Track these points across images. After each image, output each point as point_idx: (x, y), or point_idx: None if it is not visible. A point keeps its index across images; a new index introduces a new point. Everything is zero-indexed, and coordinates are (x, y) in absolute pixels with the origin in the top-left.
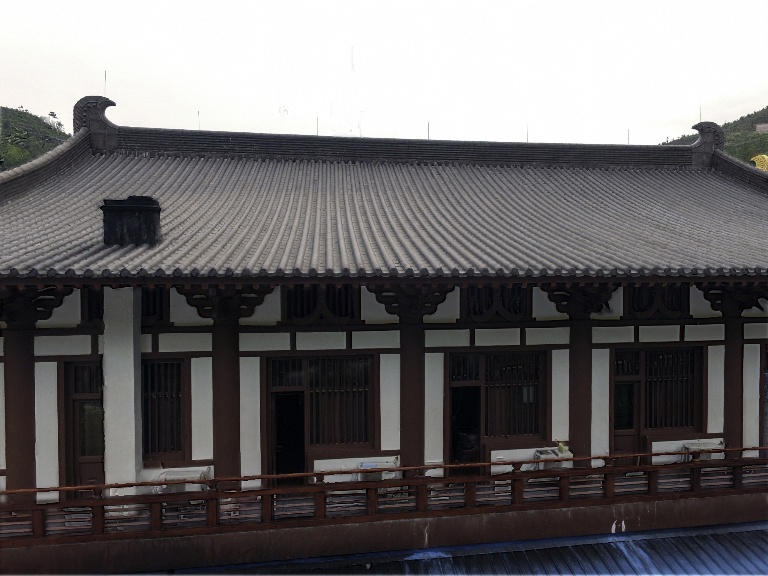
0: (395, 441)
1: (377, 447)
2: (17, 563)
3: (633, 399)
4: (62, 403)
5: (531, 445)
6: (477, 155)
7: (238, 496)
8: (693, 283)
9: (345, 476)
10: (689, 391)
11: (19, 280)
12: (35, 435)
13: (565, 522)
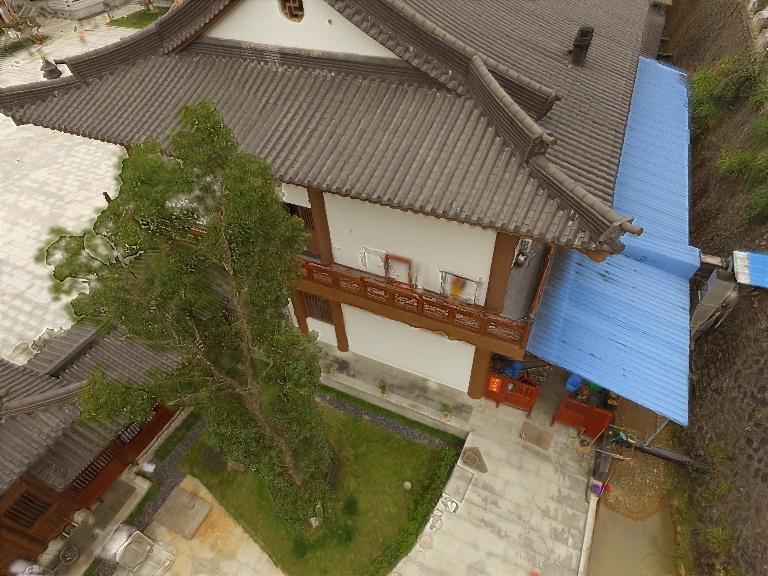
0: None
1: None
2: None
3: None
4: None
5: None
6: None
7: None
8: None
9: None
10: None
11: None
12: None
13: None
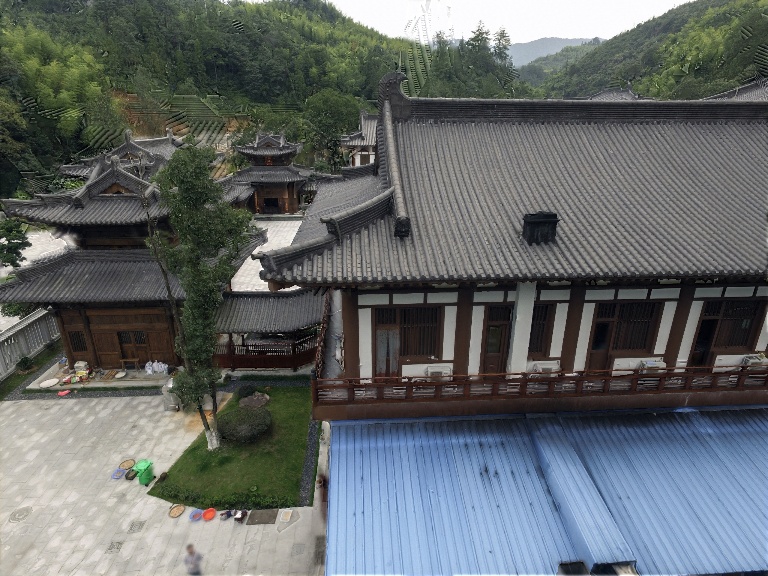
0: (663, 350)
1: (652, 353)
2: (485, 407)
3: None
4: (485, 327)
5: (742, 353)
6: (691, 114)
7: (594, 380)
8: None
9: (631, 367)
10: None
11: (526, 279)
12: (470, 343)
13: (764, 397)
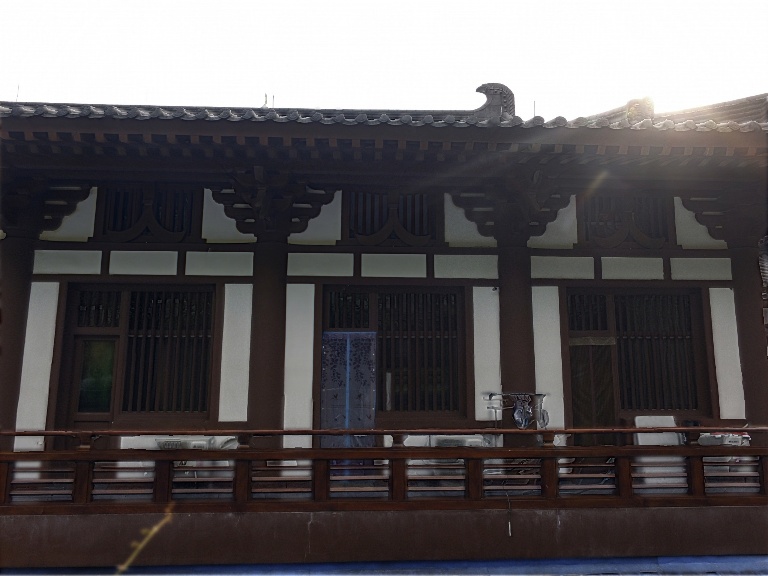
0: None
1: None
2: None
3: (113, 365)
4: None
5: None
6: None
7: None
8: (7, 133)
9: None
10: (202, 355)
11: None
12: None
13: None
